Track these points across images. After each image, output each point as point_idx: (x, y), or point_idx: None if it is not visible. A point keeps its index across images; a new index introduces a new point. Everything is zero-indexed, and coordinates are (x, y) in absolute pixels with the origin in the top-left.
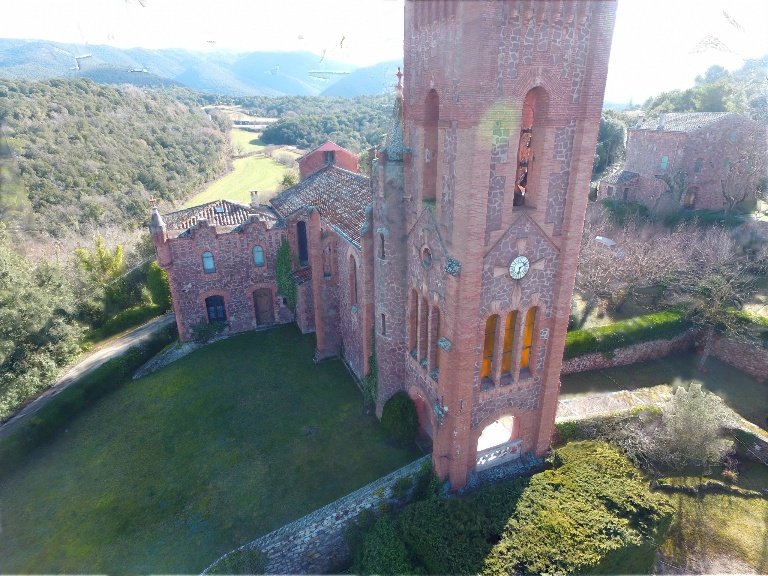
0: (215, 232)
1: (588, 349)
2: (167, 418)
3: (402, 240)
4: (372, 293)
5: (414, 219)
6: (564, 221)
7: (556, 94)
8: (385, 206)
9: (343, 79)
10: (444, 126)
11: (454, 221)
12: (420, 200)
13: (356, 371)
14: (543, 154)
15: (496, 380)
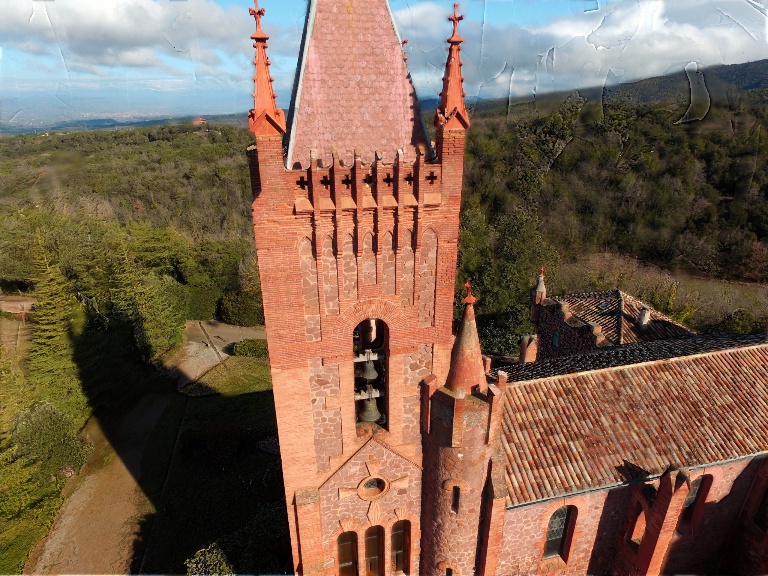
0: (564, 319)
1: None
2: None
3: None
4: None
5: None
6: None
7: None
8: None
9: None
10: None
11: None
12: None
13: None
14: None
15: None
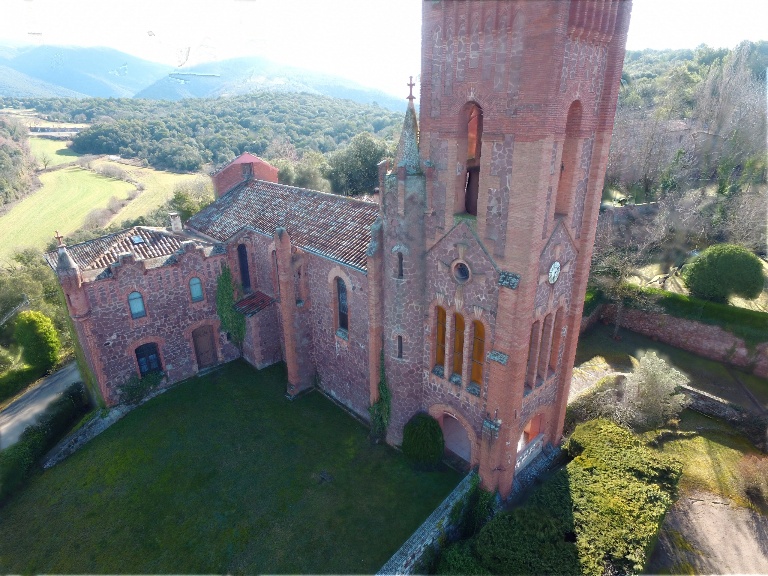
0: (143, 267)
1: None
2: (127, 507)
3: (422, 257)
4: (381, 315)
5: (439, 234)
6: (582, 224)
7: (586, 107)
8: (404, 223)
9: (212, 82)
10: (493, 139)
11: (508, 234)
12: (450, 214)
13: (344, 400)
14: (575, 163)
15: (533, 383)
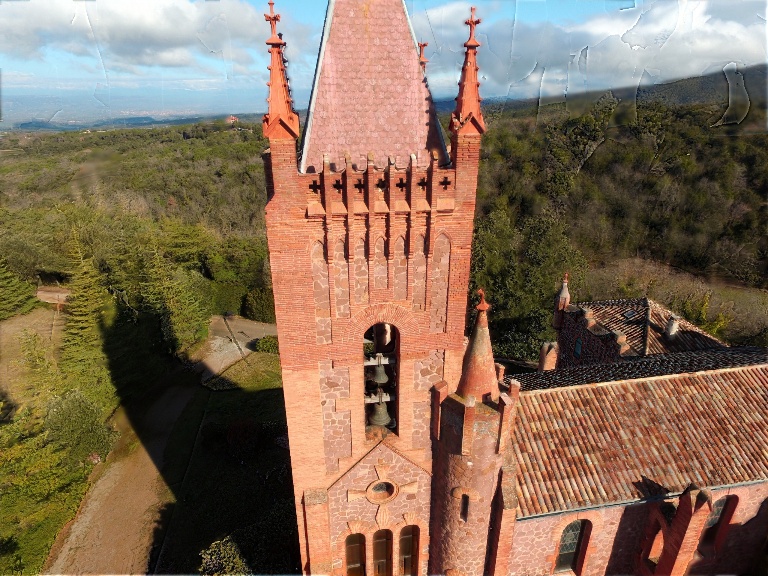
0: (587, 326)
1: None
2: None
3: None
4: None
5: None
6: None
7: None
8: None
9: None
10: None
11: None
12: None
13: None
14: None
15: None
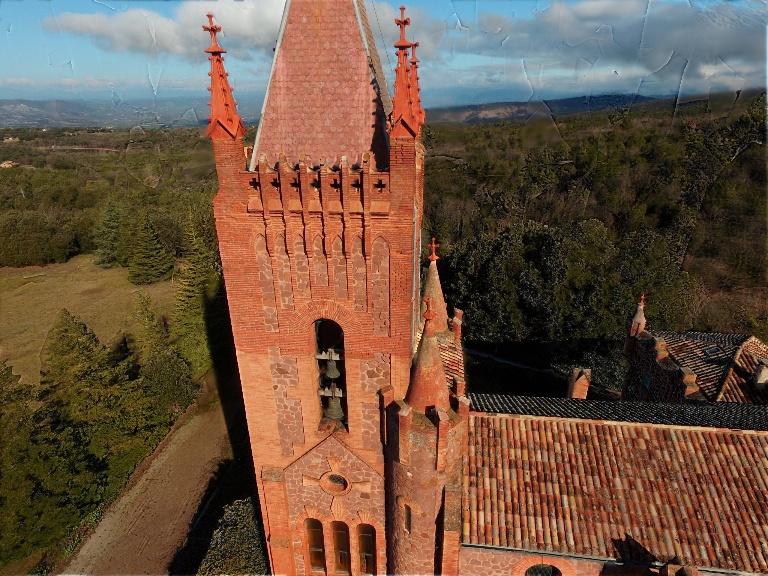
0: (656, 358)
1: None
2: None
3: None
4: None
5: None
6: None
7: None
8: None
9: None
10: None
11: None
12: None
13: None
14: None
15: None
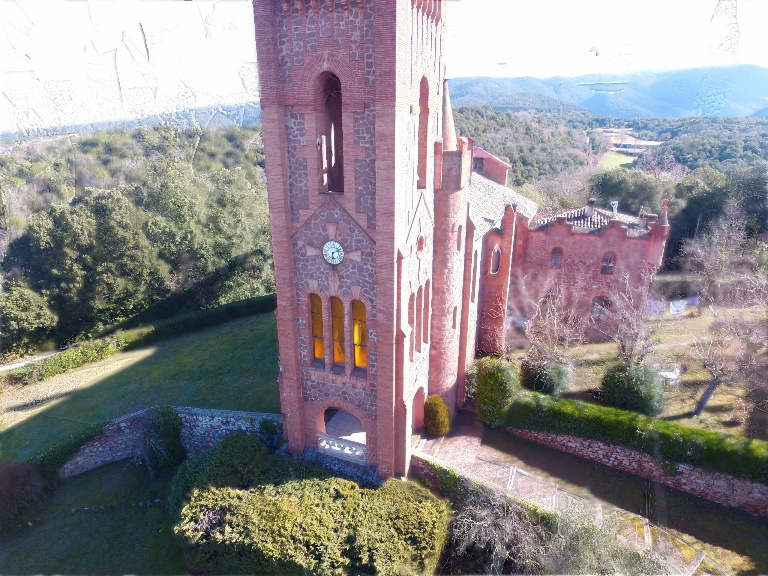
0: None
1: (628, 441)
2: (256, 334)
3: None
4: None
5: None
6: None
7: (347, 77)
8: None
9: (619, 90)
10: None
11: None
12: None
13: None
14: None
15: (326, 363)
